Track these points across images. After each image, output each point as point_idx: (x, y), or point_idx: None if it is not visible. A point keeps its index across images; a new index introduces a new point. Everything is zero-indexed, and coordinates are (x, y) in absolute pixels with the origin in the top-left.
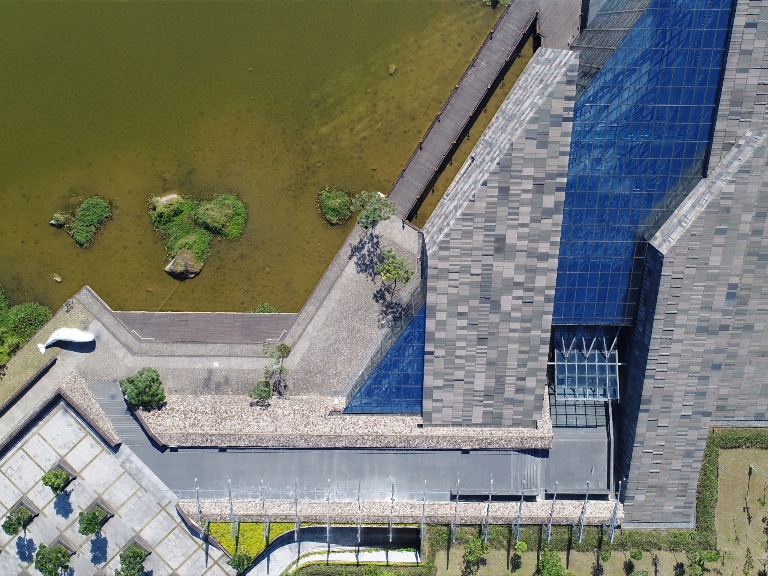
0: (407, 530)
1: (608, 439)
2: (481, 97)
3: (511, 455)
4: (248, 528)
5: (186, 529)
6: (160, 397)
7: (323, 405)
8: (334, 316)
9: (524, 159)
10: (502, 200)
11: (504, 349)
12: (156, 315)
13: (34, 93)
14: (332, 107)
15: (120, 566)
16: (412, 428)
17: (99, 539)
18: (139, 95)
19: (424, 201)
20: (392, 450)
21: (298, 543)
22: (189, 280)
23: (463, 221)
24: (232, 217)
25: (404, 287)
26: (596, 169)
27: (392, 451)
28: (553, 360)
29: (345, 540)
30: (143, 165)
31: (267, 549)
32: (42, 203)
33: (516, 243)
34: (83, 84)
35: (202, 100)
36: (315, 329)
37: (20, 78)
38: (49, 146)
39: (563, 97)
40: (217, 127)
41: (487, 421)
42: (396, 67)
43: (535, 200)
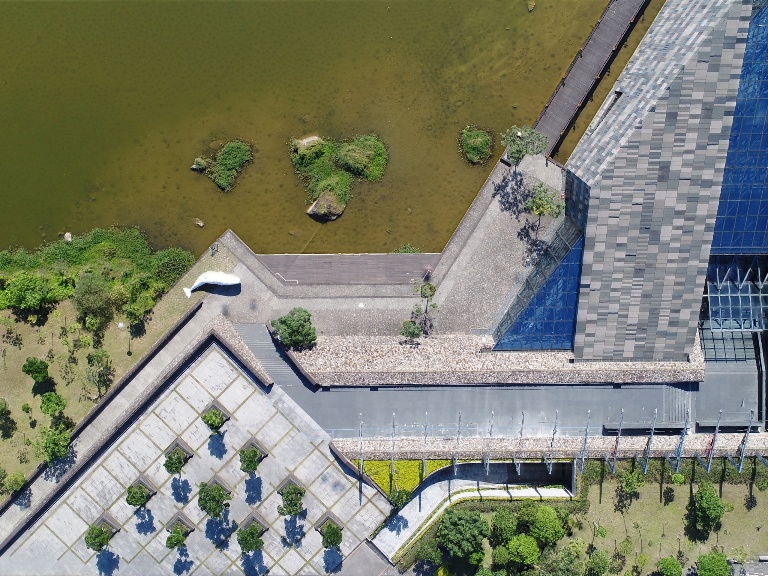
0: (553, 467)
1: (759, 371)
2: (624, 31)
3: (662, 389)
4: (402, 465)
5: (339, 468)
6: (312, 336)
7: (472, 343)
8: (479, 255)
9: (694, 83)
10: (669, 126)
11: (660, 281)
12: (300, 257)
13: (172, 37)
14: (471, 45)
15: (275, 505)
16: (564, 363)
17: (253, 479)
18: (277, 37)
19: (565, 138)
20: (543, 386)
21: (448, 481)
22: (331, 222)
23: (628, 149)
24: (373, 158)
25: (548, 224)
26: (764, 93)
27: (543, 387)
28: (706, 292)
29: (493, 478)
30: (283, 108)
31: (419, 487)
32: (182, 148)
33: (680, 171)
34: (221, 27)
35: (340, 41)
36: (460, 268)
37: (158, 23)
38: (188, 90)
39: (738, 17)
40: (356, 68)
41: (638, 355)
42: (535, 3)
43: (702, 125)
